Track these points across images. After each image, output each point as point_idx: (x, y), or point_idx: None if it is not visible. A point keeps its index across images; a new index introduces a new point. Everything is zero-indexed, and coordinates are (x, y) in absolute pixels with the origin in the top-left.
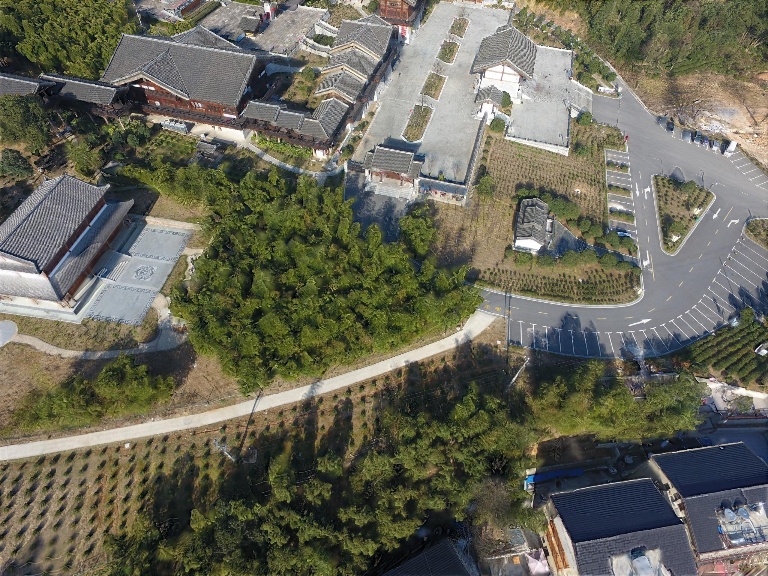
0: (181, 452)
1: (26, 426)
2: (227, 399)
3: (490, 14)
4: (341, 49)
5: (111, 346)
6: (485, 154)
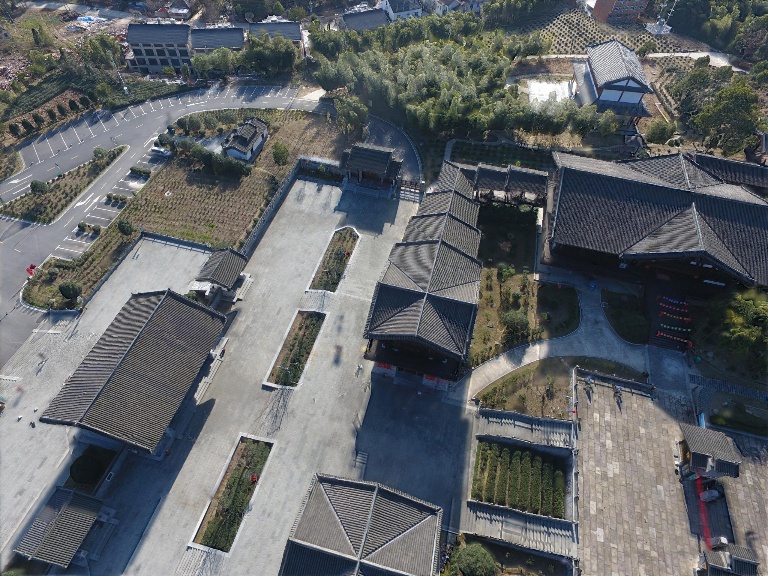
0: None
1: None
2: None
3: None
4: None
5: None
6: None
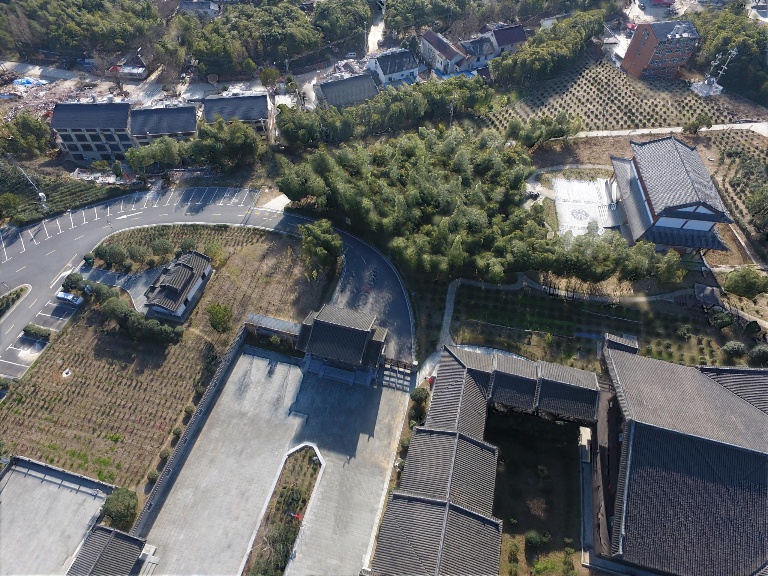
0: None
1: None
2: None
3: None
4: None
5: None
6: (181, 430)
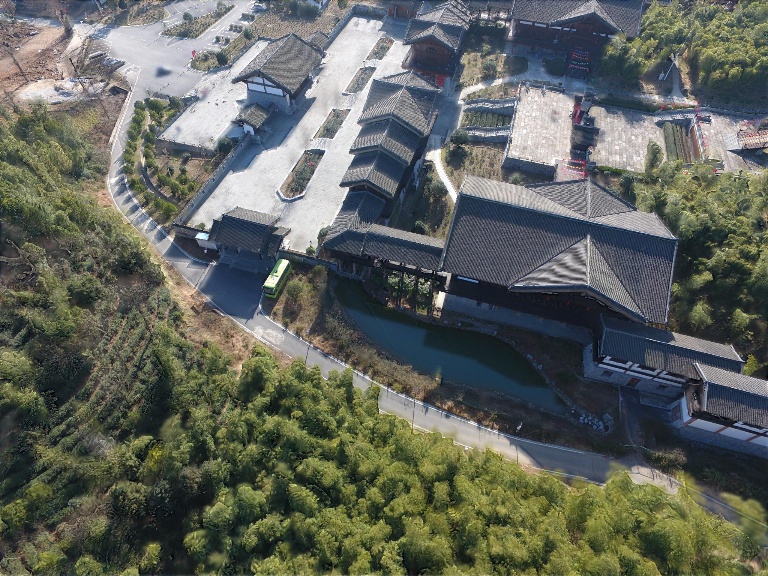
0: None
1: None
2: None
3: None
4: None
5: None
6: None
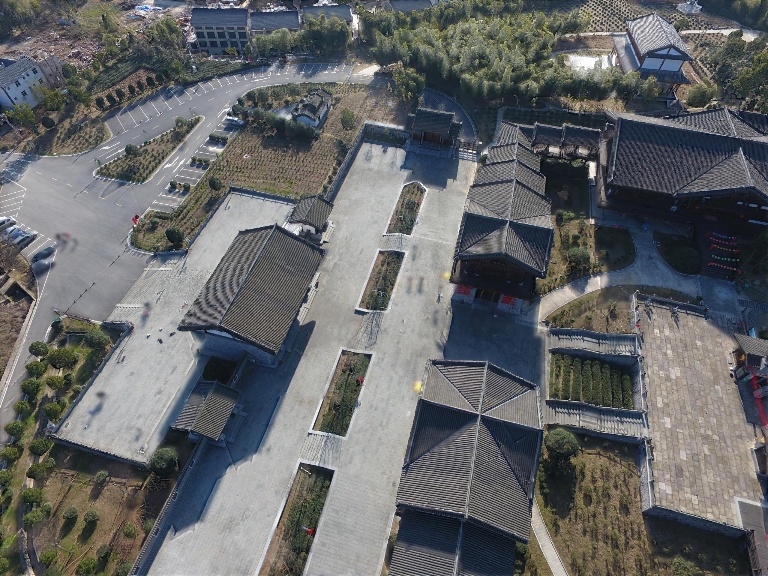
0: None
1: None
2: None
3: None
4: None
5: None
6: None
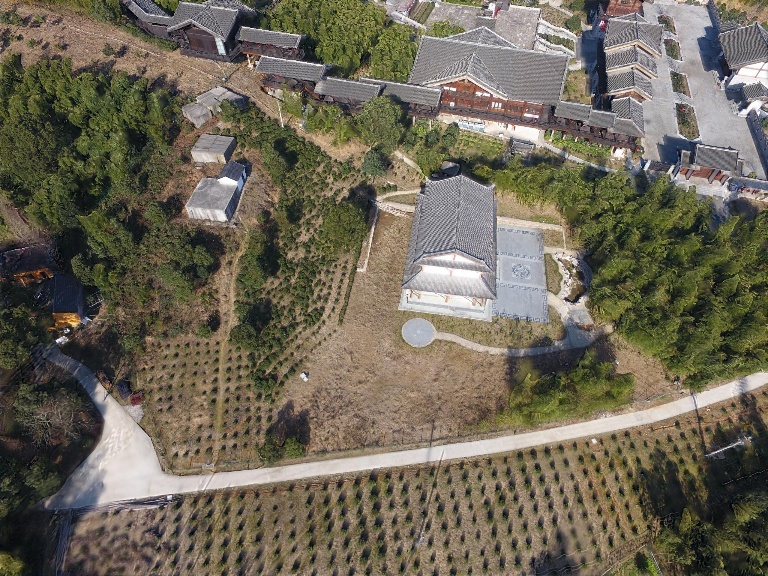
0: (650, 448)
1: (489, 421)
2: (665, 396)
3: (688, 11)
4: (619, 48)
5: (530, 343)
6: None
